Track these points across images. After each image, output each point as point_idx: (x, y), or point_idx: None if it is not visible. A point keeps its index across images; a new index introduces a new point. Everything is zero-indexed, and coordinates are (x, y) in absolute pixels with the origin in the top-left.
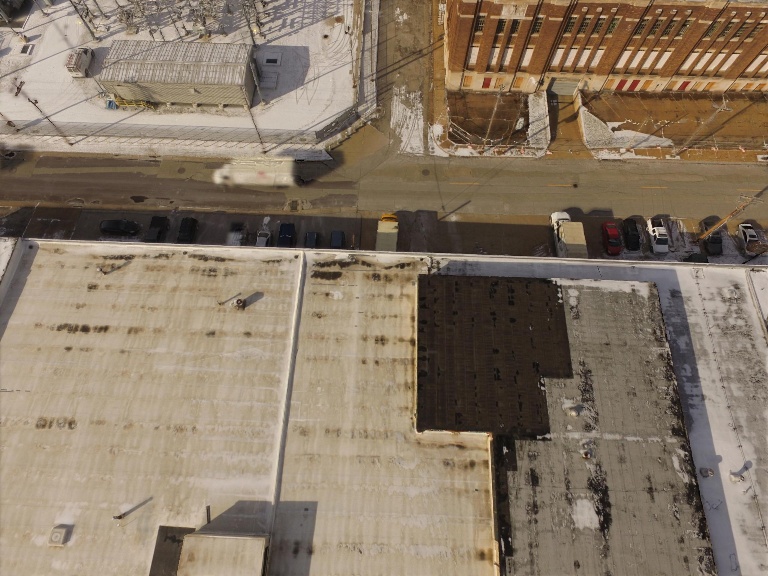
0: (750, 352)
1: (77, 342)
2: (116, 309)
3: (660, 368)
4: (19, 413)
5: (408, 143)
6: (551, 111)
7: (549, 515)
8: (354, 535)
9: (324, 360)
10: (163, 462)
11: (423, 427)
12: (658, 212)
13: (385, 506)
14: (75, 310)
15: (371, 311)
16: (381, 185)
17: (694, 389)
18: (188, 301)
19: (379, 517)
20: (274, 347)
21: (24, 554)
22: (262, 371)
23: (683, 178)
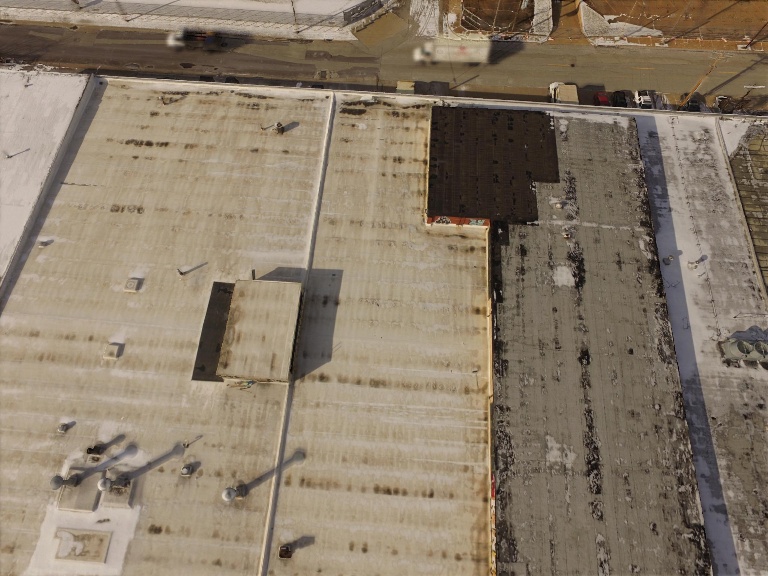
0: (713, 179)
1: (143, 153)
2: (175, 130)
3: (634, 179)
4: (96, 201)
5: (425, 28)
6: (554, 7)
7: (534, 276)
8: (373, 293)
9: (350, 172)
10: (216, 239)
11: (432, 214)
12: (645, 88)
13: (399, 275)
14: (140, 130)
15: (390, 139)
16: (400, 61)
17: (663, 203)
18: (235, 126)
19: (394, 282)
20: (308, 162)
21: (105, 296)
22: (298, 178)
23: (669, 62)
